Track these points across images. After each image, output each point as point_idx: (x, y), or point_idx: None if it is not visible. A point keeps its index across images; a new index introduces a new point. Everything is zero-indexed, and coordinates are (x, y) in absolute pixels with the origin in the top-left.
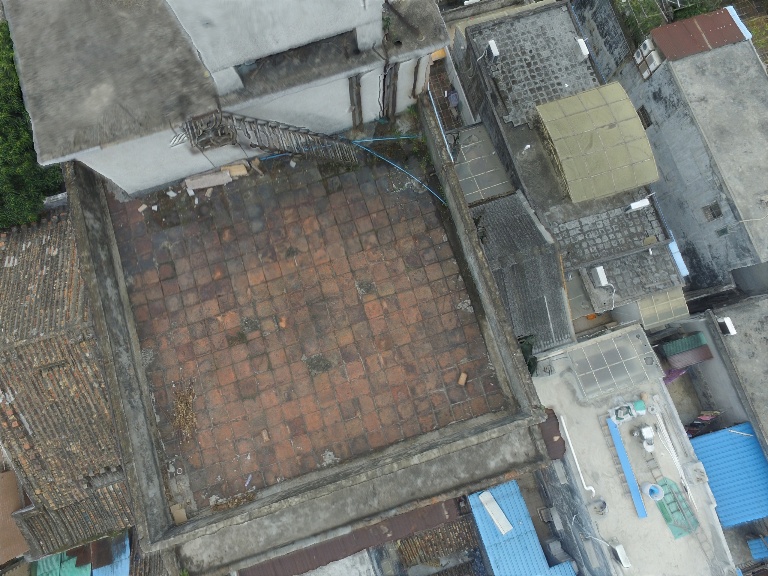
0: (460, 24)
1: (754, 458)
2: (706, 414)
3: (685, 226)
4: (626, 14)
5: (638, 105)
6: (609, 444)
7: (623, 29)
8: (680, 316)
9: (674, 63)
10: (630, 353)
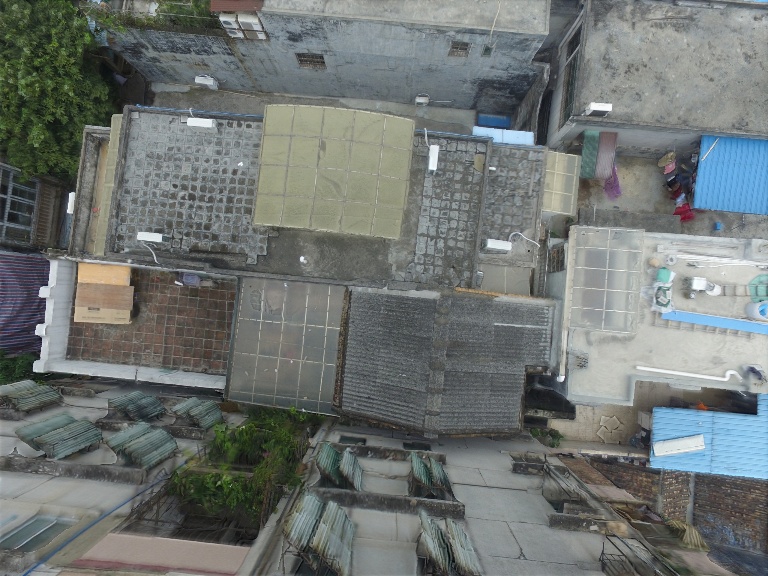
0: (95, 250)
1: (741, 149)
2: (666, 165)
3: (454, 77)
4: (174, 20)
5: (292, 57)
6: (689, 328)
7: (191, 32)
8: (576, 168)
9: (266, 5)
10: (601, 255)
